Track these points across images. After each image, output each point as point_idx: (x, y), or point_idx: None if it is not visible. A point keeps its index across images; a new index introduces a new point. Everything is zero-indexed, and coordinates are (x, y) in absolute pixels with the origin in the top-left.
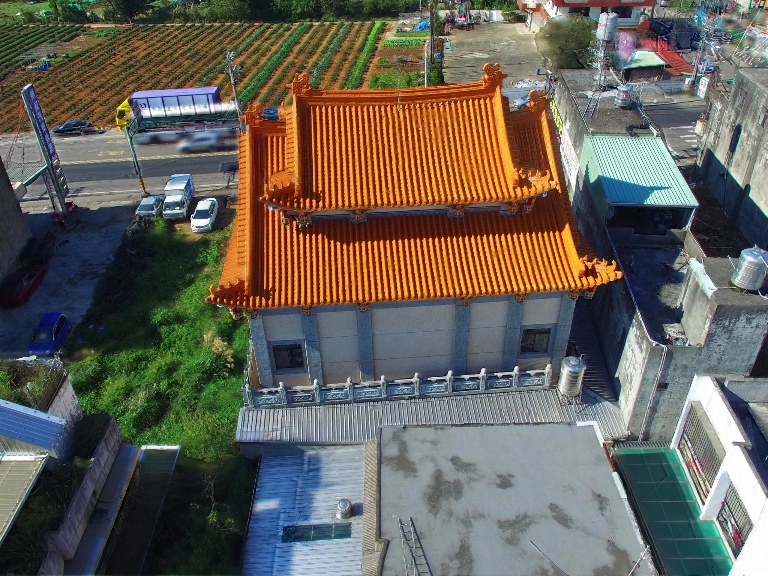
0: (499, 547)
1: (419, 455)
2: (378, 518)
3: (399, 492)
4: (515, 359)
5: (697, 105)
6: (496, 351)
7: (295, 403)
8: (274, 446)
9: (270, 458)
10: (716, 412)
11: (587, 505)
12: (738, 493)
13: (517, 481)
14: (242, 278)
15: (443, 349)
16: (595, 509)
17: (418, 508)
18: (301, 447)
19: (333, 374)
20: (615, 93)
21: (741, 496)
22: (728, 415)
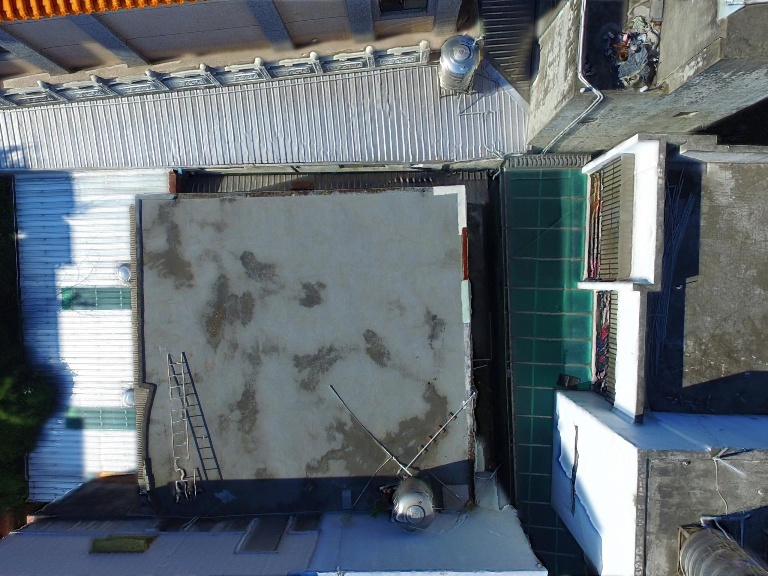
0: (291, 394)
1: (196, 250)
2: (140, 354)
3: (168, 313)
4: (370, 25)
5: None
6: (336, 16)
7: (29, 104)
8: (22, 170)
9: (26, 181)
10: (643, 199)
11: (414, 332)
12: (617, 328)
13: (328, 295)
14: None
15: (240, 20)
16: (423, 338)
17: (193, 338)
18: (61, 170)
19: (72, 56)
20: None
21: (618, 334)
22: (652, 227)
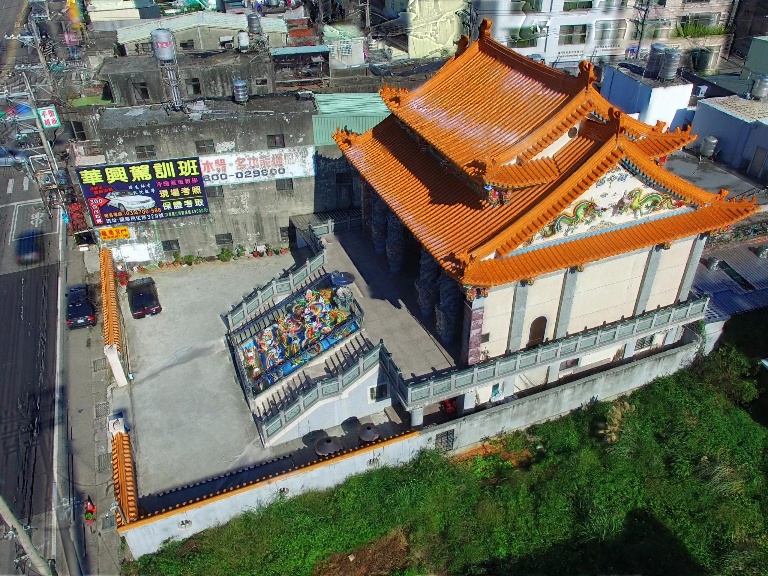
0: None
1: None
2: None
3: None
4: None
5: (59, 135)
6: None
7: None
8: None
9: None
10: None
11: None
12: None
13: None
14: (708, 210)
15: None
16: None
17: None
18: None
19: None
20: (197, 105)
21: None
22: None
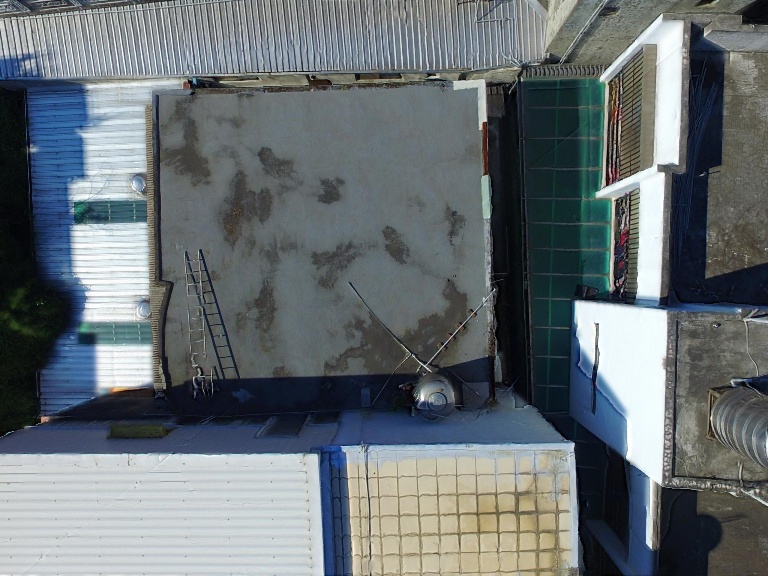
0: (309, 291)
1: (213, 146)
2: (157, 252)
3: (185, 210)
4: None
5: None
6: None
7: (43, 9)
8: (35, 81)
9: (38, 94)
10: (666, 85)
11: (434, 228)
12: (639, 220)
13: (347, 191)
14: None
15: None
16: (443, 235)
17: (210, 235)
18: (74, 81)
19: None
20: None
21: (640, 226)
22: (677, 108)
